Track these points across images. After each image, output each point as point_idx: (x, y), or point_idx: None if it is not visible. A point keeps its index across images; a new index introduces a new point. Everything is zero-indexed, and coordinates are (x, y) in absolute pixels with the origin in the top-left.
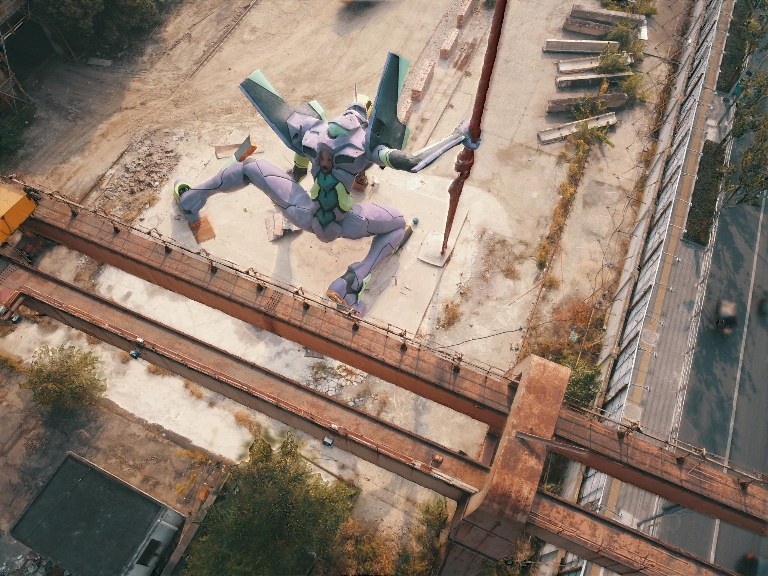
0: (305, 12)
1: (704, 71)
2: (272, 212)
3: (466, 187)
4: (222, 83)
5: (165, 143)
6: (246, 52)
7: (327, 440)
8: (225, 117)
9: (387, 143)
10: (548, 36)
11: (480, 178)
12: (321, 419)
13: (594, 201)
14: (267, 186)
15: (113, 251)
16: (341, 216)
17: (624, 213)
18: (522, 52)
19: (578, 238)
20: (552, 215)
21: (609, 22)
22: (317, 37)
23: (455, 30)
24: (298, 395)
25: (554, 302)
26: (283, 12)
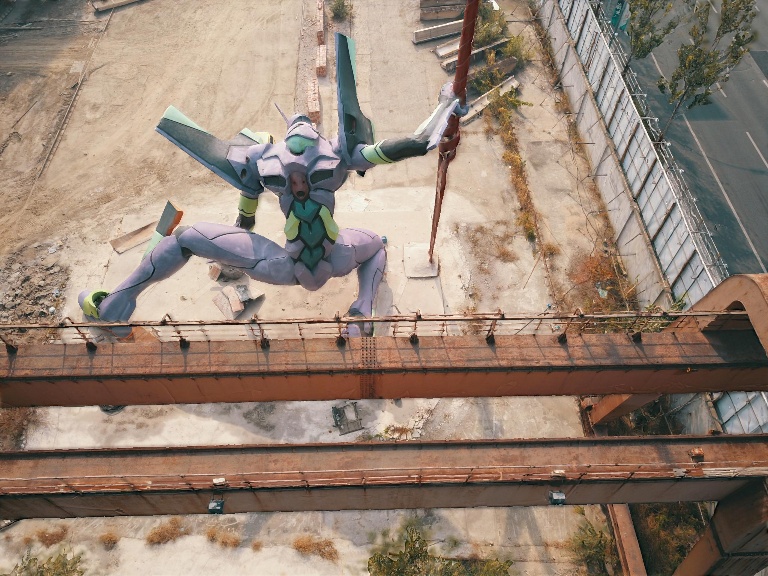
0: (147, 74)
1: (589, 7)
2: (217, 289)
3: (414, 189)
4: (83, 172)
5: (41, 260)
6: (97, 131)
7: (557, 496)
8: (105, 207)
9: (363, 141)
10: (411, 30)
11: (423, 176)
12: (530, 472)
13: (542, 161)
14: (219, 250)
15: (101, 377)
16: (330, 249)
17: (575, 162)
18: (395, 50)
19: (548, 199)
20: (512, 187)
21: (458, 4)
22: (174, 94)
23: (321, 46)
24: (478, 456)
25: (564, 268)
26: (121, 80)
